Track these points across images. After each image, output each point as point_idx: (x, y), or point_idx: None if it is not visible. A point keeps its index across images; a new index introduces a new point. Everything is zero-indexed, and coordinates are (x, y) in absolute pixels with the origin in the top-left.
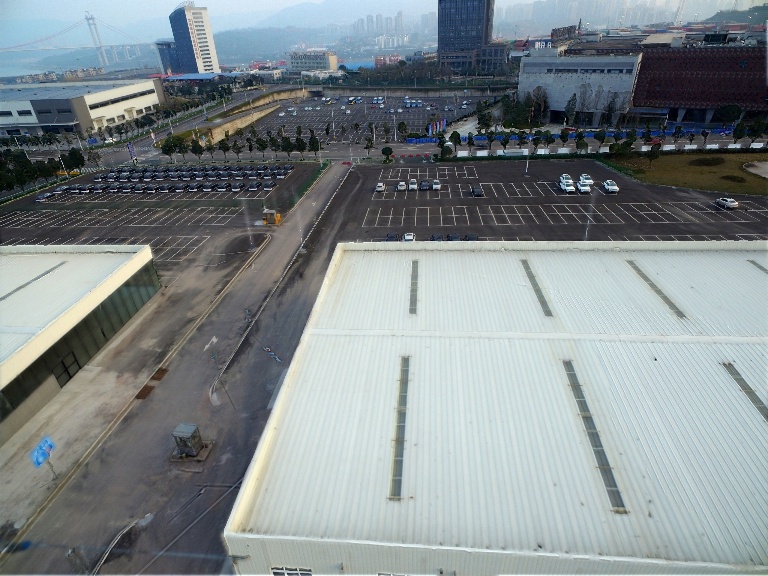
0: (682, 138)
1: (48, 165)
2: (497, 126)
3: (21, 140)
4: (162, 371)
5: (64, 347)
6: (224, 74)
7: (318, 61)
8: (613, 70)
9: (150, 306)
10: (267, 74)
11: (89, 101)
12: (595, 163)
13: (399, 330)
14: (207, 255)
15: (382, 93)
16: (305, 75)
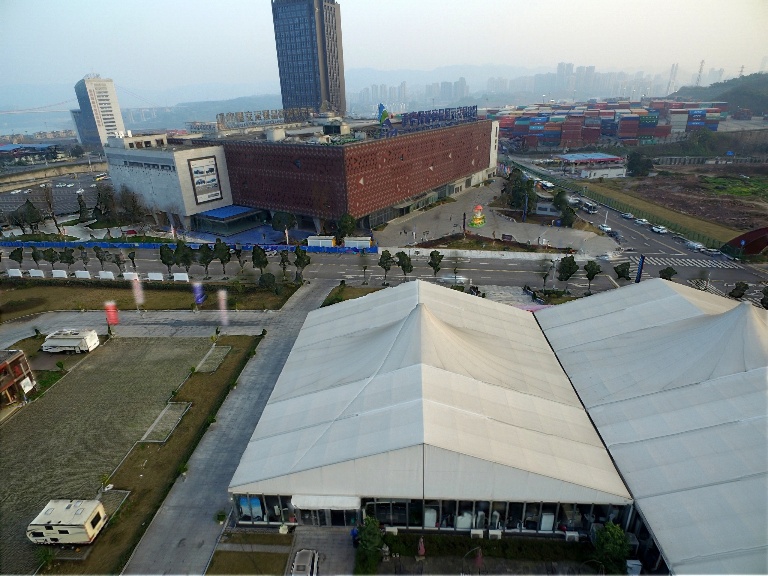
0: (104, 261)
1: None
2: None
3: None
4: None
5: None
6: (35, 146)
7: None
8: (165, 166)
9: None
10: None
11: None
12: None
13: None
14: None
15: None
16: None
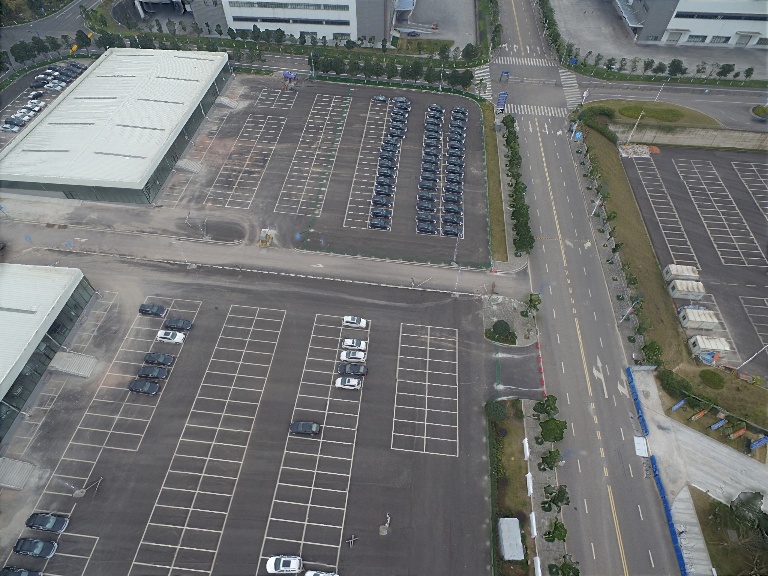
0: None
1: (437, 73)
2: None
3: (550, 24)
4: (65, 227)
5: (70, 188)
6: None
7: None
8: None
9: (135, 206)
10: None
11: (684, 7)
12: None
13: None
14: (207, 214)
15: None
16: None
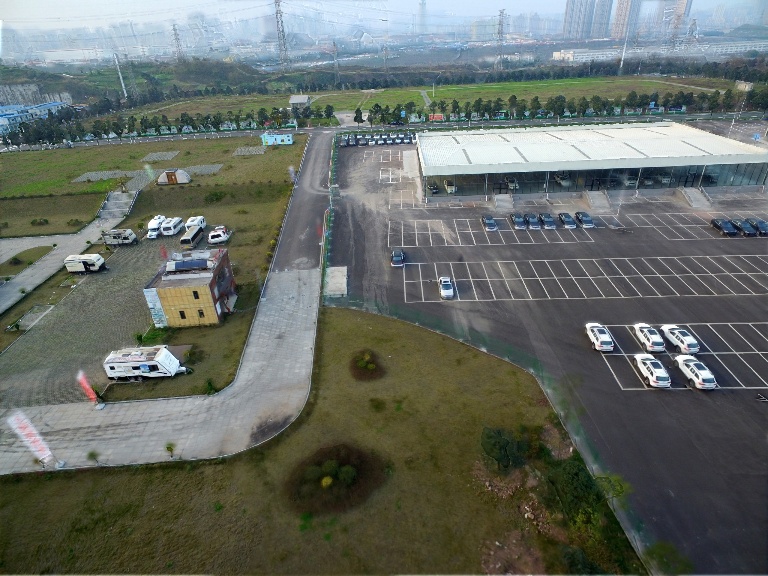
0: None
1: None
2: None
3: None
4: None
5: None
6: None
7: None
8: None
9: None
10: None
11: None
12: (665, 561)
13: (680, 137)
14: None
15: None
16: None
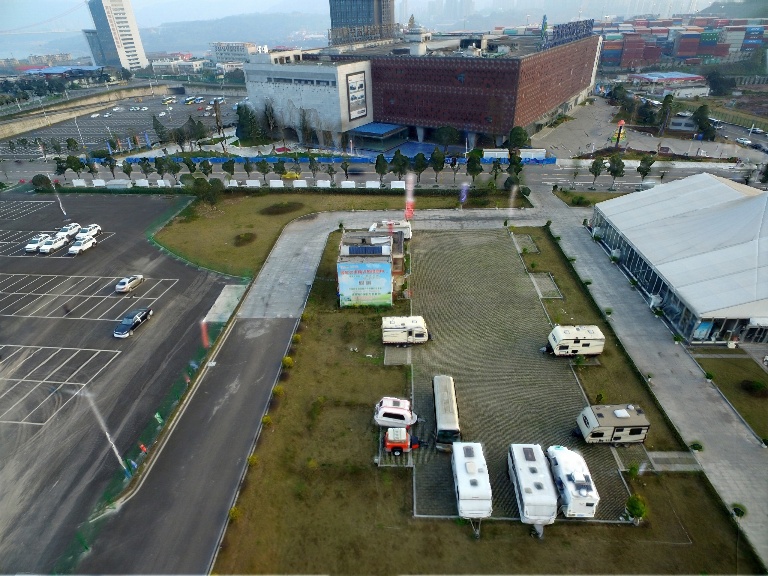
0: (318, 172)
1: None
2: (192, 144)
3: None
4: None
5: None
6: (84, 68)
7: (239, 52)
8: (321, 82)
9: None
10: (187, 65)
11: None
12: (184, 202)
13: None
14: None
15: (235, 92)
16: (219, 67)
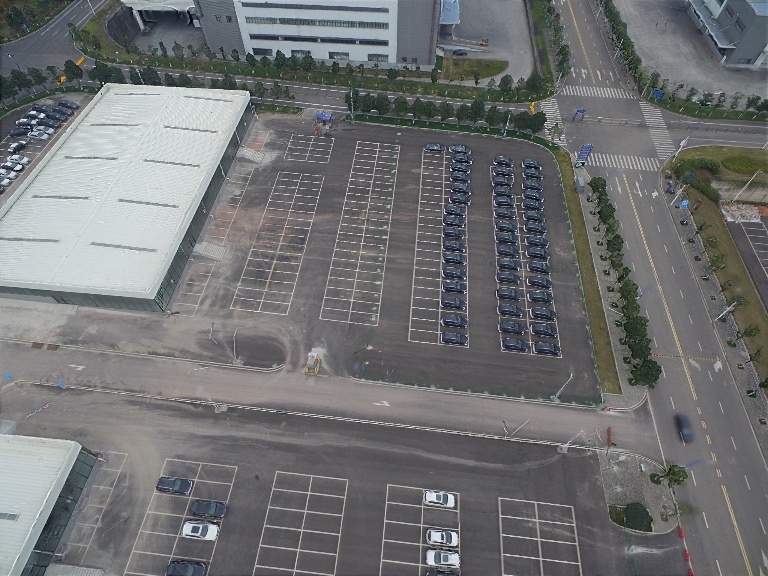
0: None
1: (502, 114)
2: None
3: (626, 45)
4: (56, 347)
5: (62, 294)
6: None
7: None
8: None
9: (144, 313)
10: None
11: None
12: None
13: None
14: (236, 325)
15: None
16: None
